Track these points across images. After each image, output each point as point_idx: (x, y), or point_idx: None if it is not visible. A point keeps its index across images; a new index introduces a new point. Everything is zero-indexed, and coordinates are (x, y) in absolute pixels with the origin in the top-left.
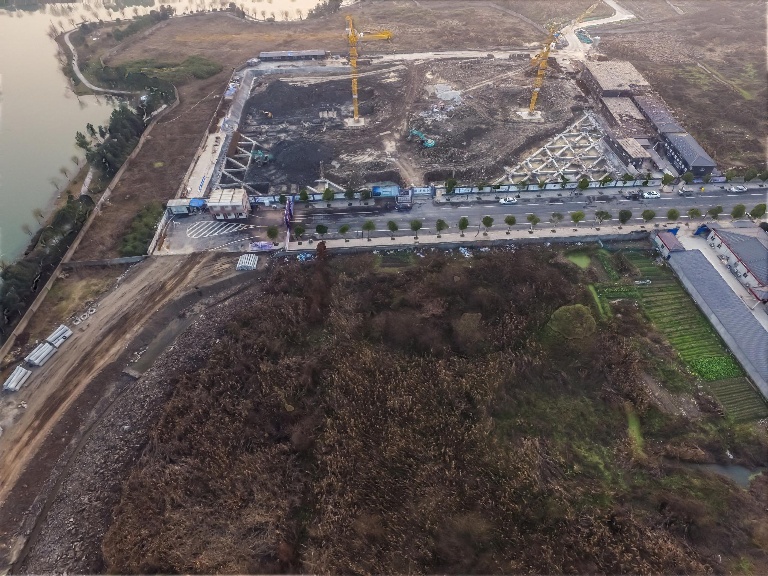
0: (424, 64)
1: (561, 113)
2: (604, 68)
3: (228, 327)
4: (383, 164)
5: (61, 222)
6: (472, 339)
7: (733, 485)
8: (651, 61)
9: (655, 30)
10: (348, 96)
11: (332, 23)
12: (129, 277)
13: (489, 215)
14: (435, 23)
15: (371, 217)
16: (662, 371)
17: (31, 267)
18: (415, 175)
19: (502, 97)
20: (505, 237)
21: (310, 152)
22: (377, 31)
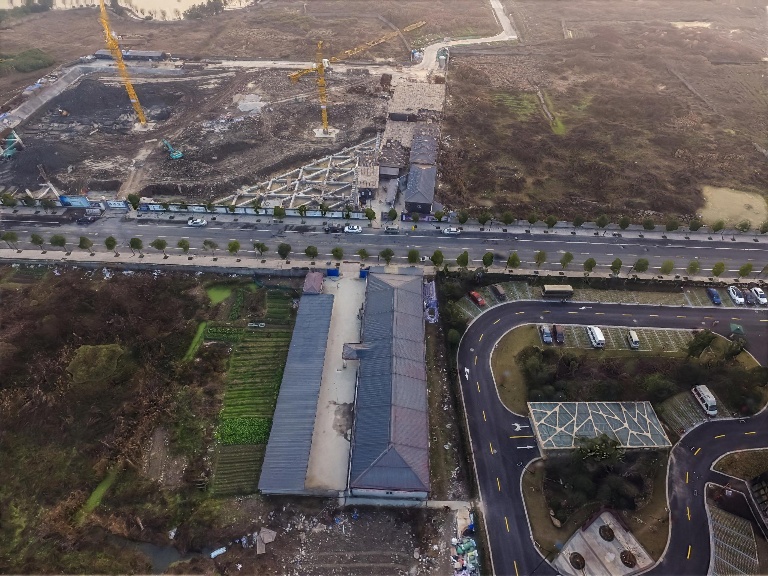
0: (255, 73)
1: (352, 133)
2: (411, 90)
3: None
4: (114, 173)
5: None
6: None
7: (140, 571)
8: (490, 86)
9: (523, 53)
10: (158, 100)
11: (205, 25)
12: None
13: (165, 236)
14: (306, 32)
15: (45, 227)
16: (182, 428)
17: None
18: (135, 187)
19: (307, 112)
20: (158, 261)
21: (45, 154)
22: (242, 36)
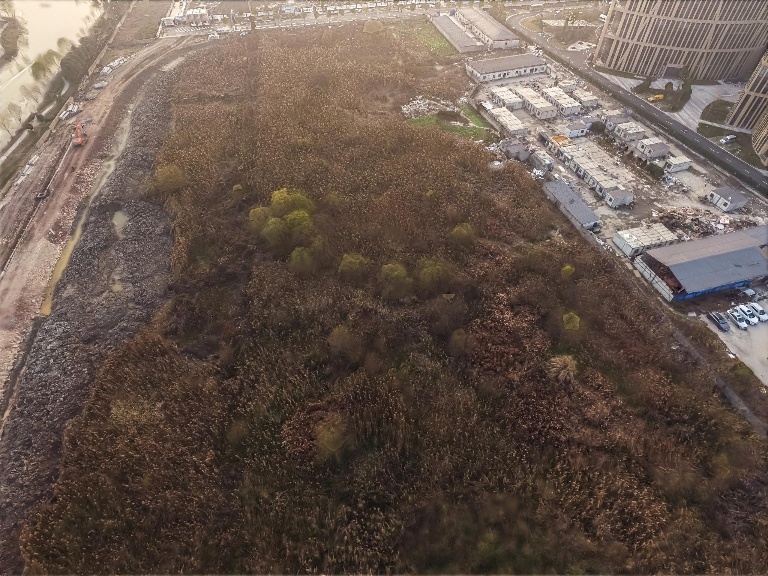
0: None
1: None
2: None
3: (209, 50)
4: None
5: (102, 26)
6: (328, 39)
7: None
8: None
9: None
10: None
11: None
12: (149, 45)
13: (345, 16)
14: None
15: (280, 21)
16: None
17: (94, 39)
18: None
19: None
20: None
21: (241, 1)
22: None
